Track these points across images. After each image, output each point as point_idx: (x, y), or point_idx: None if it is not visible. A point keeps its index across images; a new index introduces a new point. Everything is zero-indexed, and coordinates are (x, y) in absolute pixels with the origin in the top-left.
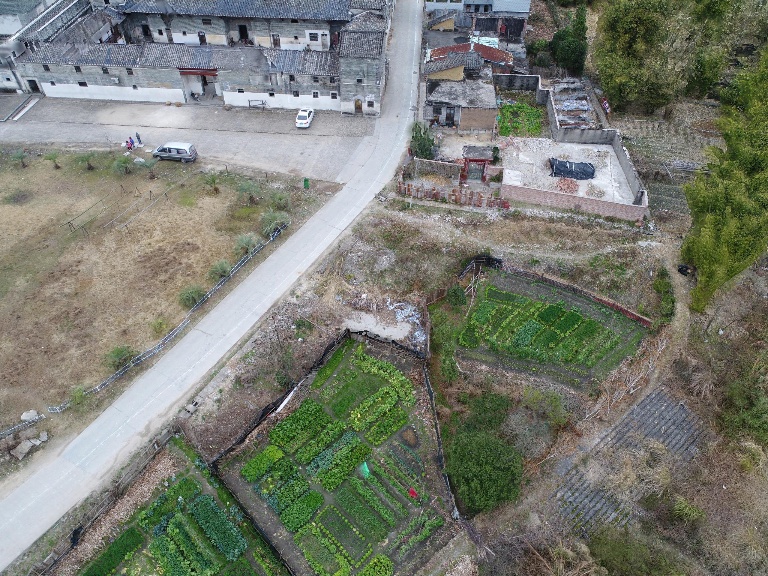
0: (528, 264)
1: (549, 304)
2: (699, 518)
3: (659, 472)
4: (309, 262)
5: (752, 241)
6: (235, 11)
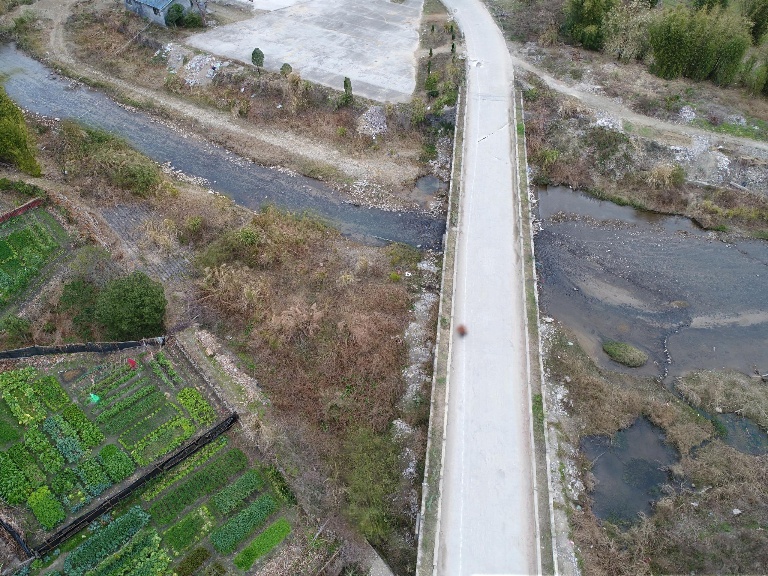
0: None
1: None
2: (202, 220)
3: (166, 226)
4: None
5: (7, 105)
6: None
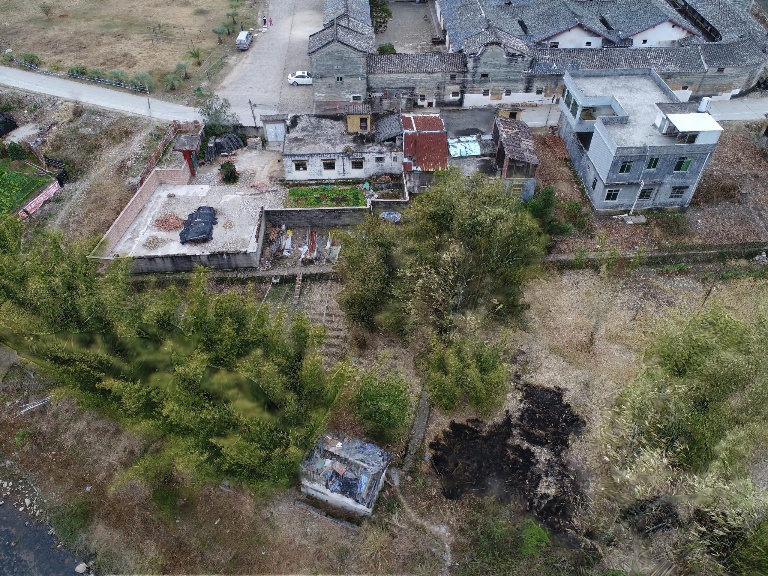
0: (56, 197)
1: (7, 210)
2: None
3: None
4: (97, 103)
5: None
6: (445, 2)
